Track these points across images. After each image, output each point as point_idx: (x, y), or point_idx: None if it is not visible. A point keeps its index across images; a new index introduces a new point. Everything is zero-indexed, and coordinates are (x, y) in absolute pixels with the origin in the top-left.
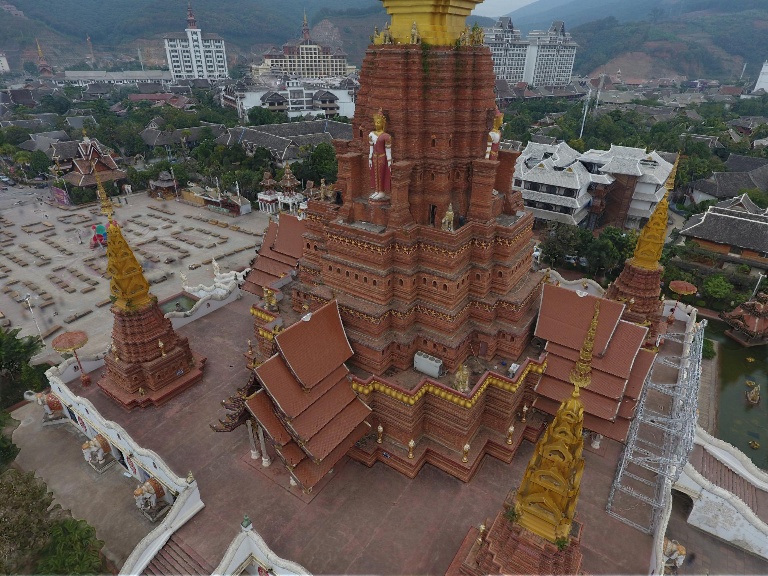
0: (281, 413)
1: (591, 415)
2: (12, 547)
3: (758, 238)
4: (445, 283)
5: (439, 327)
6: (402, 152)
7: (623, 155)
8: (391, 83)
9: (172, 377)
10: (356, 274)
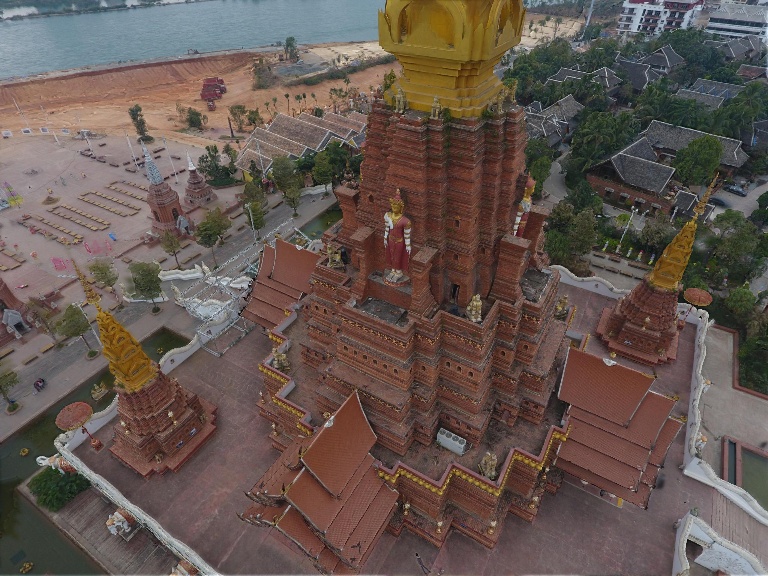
0: None
1: None
2: None
3: None
4: None
5: None
6: None
7: None
8: None
9: None
10: None
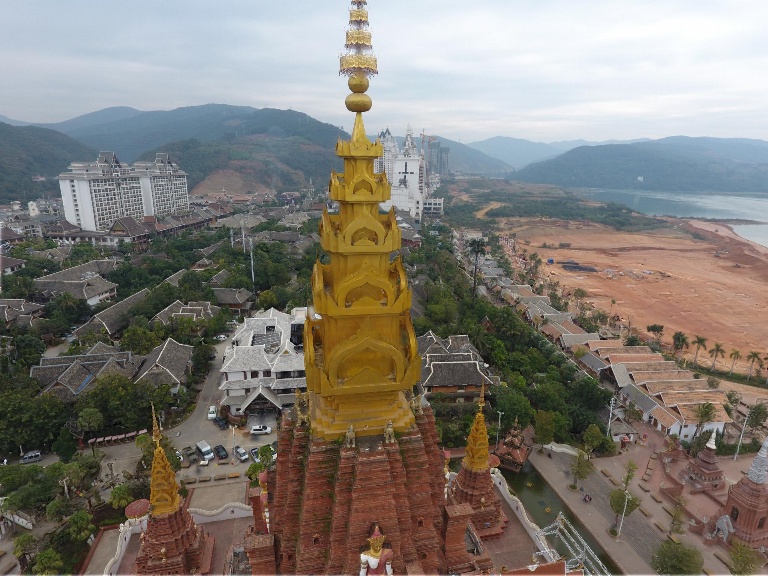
0: None
1: None
2: None
3: (470, 375)
4: None
5: None
6: (401, 556)
7: None
8: (380, 493)
9: None
10: None
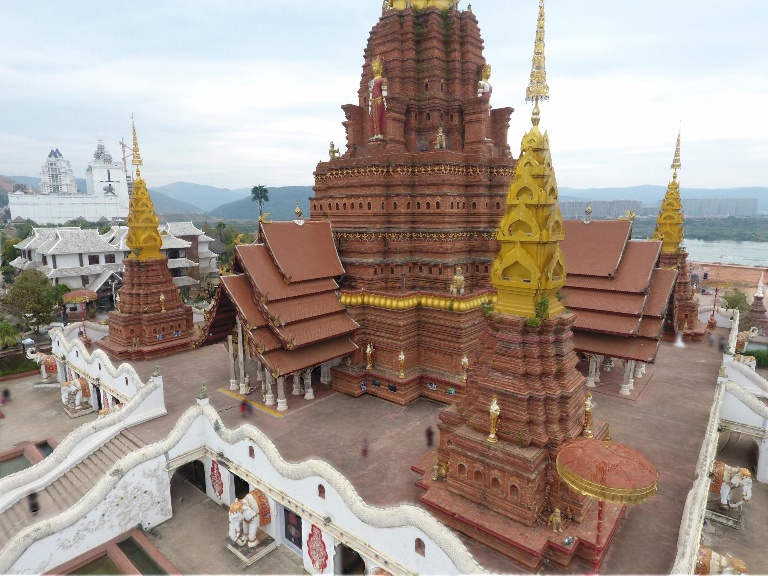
0: None
1: None
2: None
3: None
4: None
5: None
6: None
7: None
8: (479, 44)
9: None
10: None
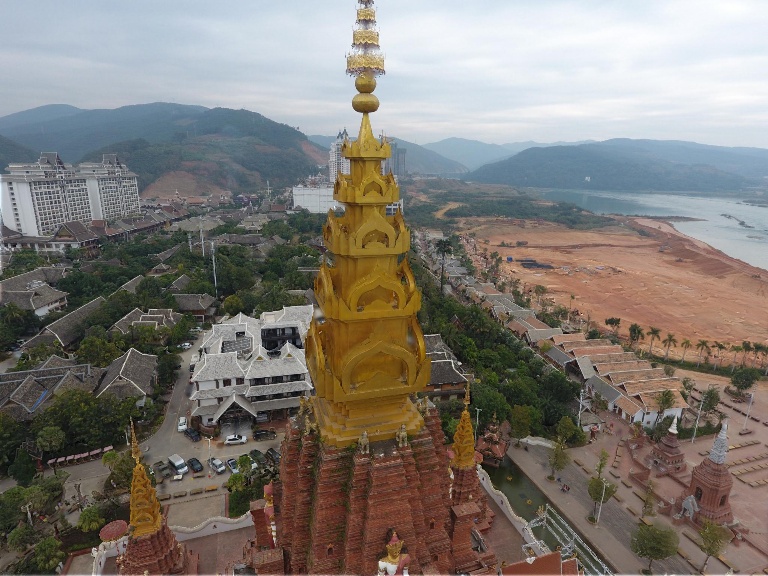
0: None
1: None
2: None
3: (446, 373)
4: None
5: None
6: None
7: (298, 314)
8: (397, 498)
9: None
10: None
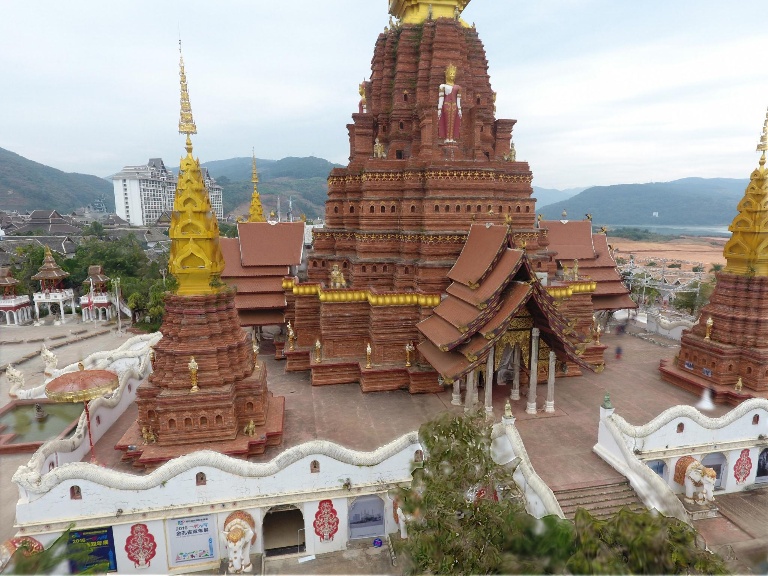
0: (548, 299)
1: (613, 297)
2: (485, 573)
3: None
4: (527, 205)
5: (528, 247)
6: None
7: None
8: (452, 46)
9: (266, 404)
10: (468, 205)
